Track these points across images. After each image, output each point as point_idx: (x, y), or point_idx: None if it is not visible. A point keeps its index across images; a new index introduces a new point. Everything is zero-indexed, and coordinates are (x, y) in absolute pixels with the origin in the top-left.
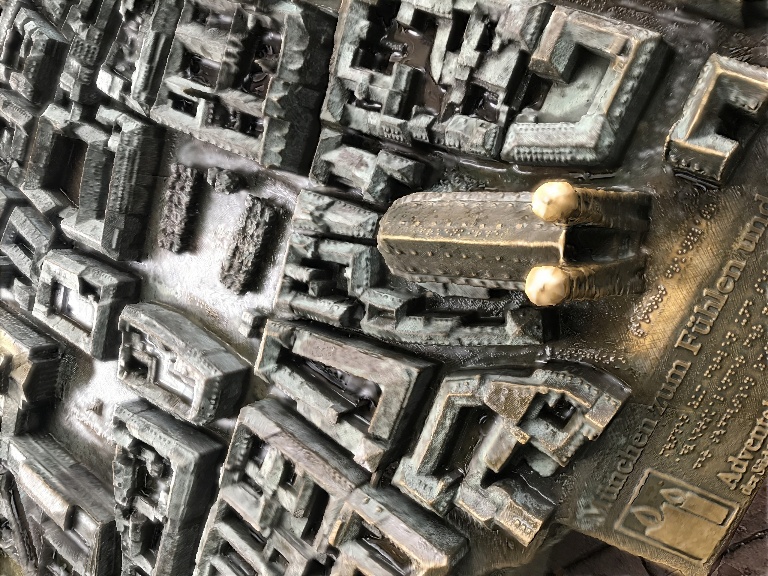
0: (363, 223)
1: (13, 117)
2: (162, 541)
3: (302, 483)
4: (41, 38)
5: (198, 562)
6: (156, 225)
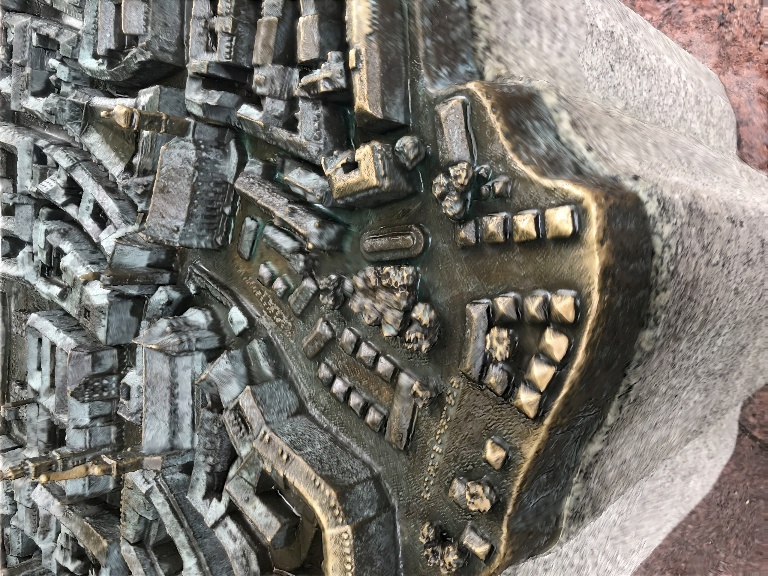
0: None
1: (12, 89)
2: None
3: None
4: (48, 117)
5: None
6: None
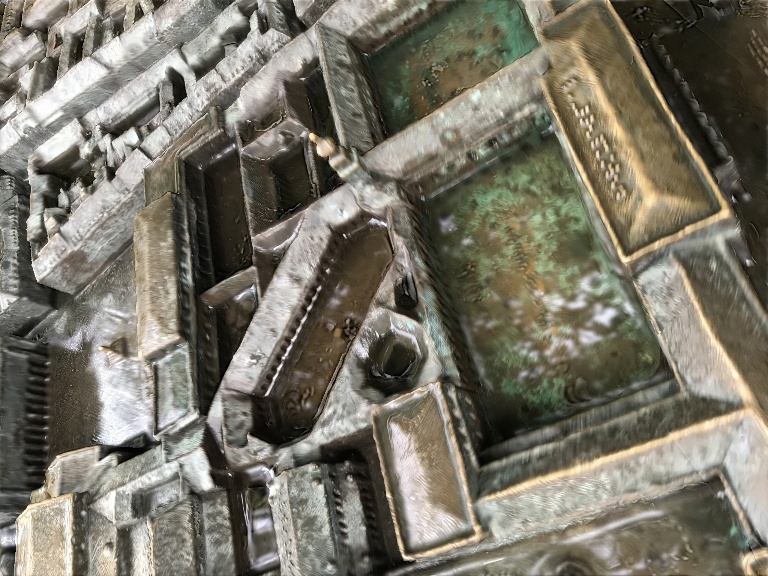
0: None
1: None
2: (107, 104)
3: (5, 81)
4: None
5: (84, 61)
6: None
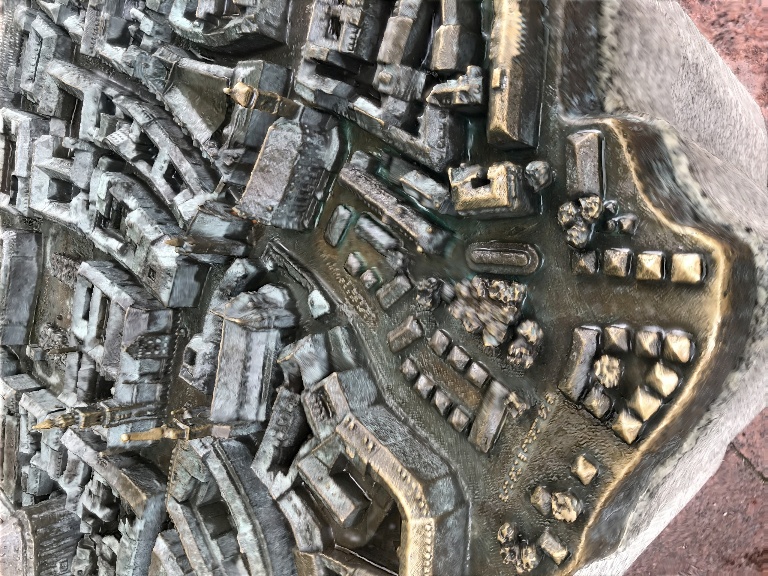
0: (50, 476)
1: (85, 32)
2: None
3: None
4: (127, 69)
5: None
6: (73, 233)
